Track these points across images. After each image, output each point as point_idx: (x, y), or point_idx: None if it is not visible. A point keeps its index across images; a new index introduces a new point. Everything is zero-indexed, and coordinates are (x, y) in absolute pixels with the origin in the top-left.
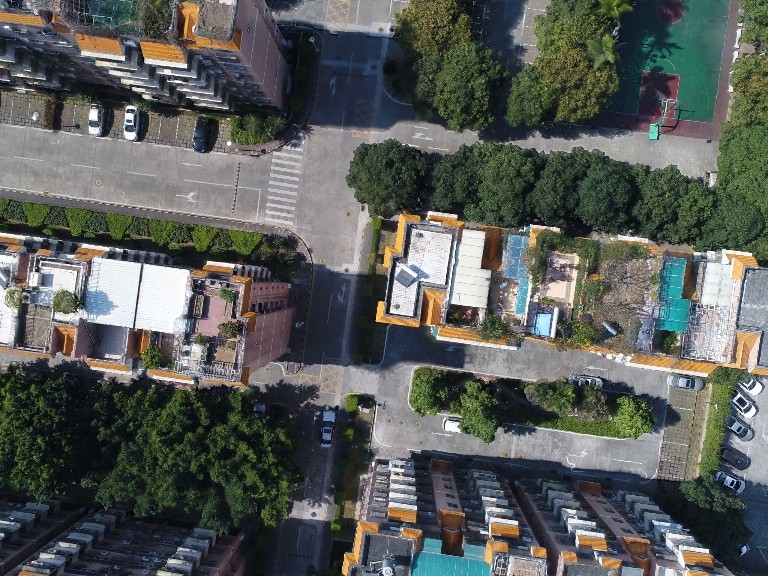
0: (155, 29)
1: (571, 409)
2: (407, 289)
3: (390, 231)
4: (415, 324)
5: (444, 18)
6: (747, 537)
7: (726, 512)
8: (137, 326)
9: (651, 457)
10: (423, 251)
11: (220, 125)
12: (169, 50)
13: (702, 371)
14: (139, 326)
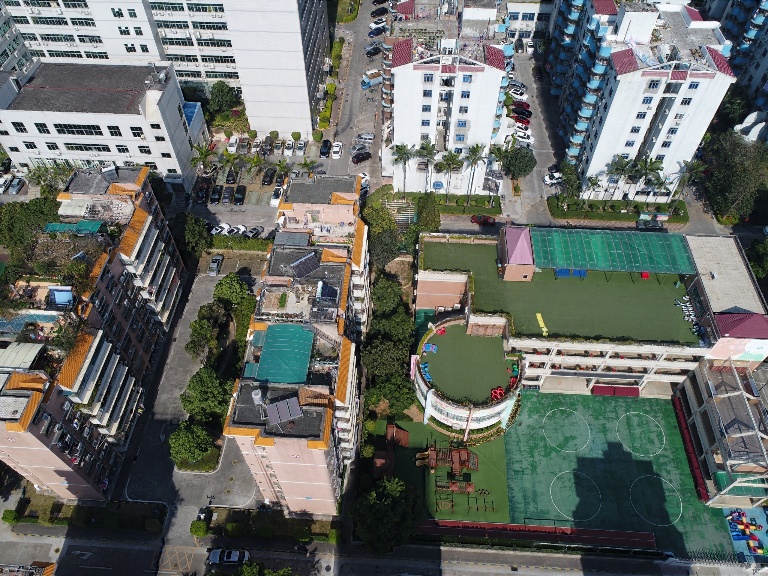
0: None
1: (205, 320)
2: (1, 405)
3: (28, 506)
4: (38, 396)
5: None
6: None
7: None
8: None
9: None
10: None
11: None
12: None
13: (145, 218)
14: None
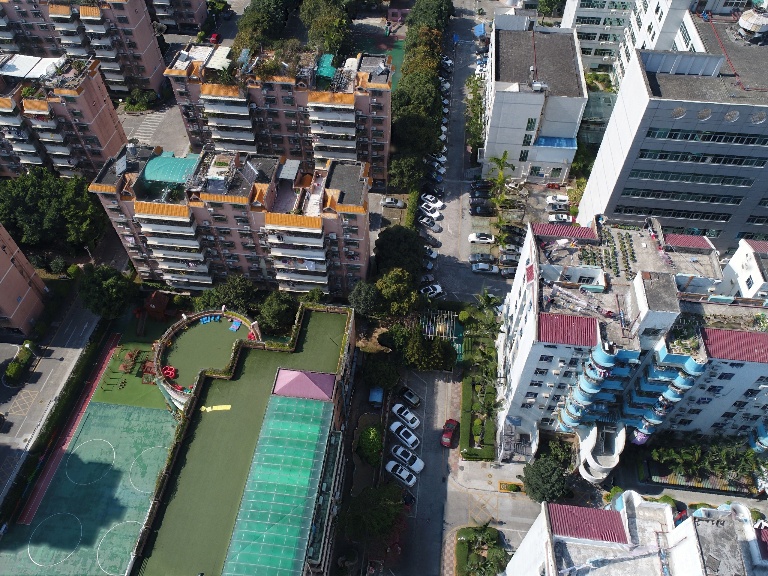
0: (89, 0)
1: None
2: (183, 63)
3: None
4: (184, 73)
5: (248, 46)
6: (420, 243)
7: (401, 226)
8: (27, 76)
9: (371, 244)
10: (196, 52)
11: (120, 105)
12: (93, 10)
13: (349, 103)
14: (28, 76)
